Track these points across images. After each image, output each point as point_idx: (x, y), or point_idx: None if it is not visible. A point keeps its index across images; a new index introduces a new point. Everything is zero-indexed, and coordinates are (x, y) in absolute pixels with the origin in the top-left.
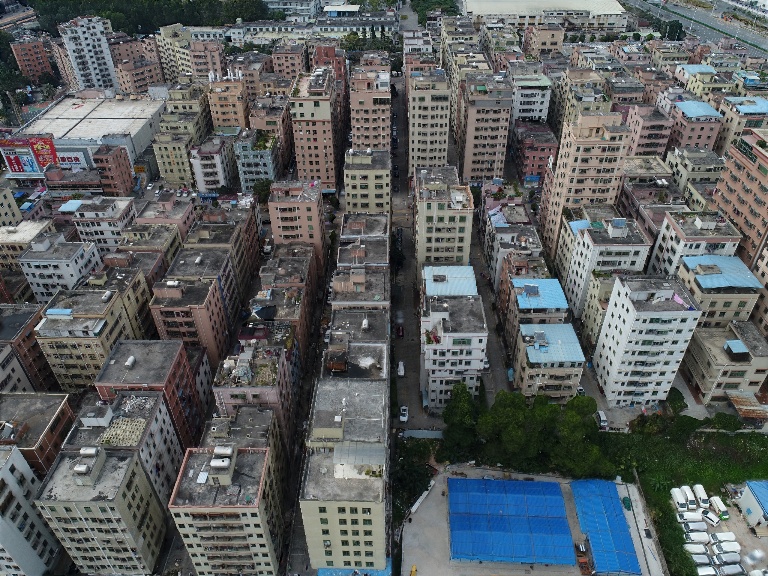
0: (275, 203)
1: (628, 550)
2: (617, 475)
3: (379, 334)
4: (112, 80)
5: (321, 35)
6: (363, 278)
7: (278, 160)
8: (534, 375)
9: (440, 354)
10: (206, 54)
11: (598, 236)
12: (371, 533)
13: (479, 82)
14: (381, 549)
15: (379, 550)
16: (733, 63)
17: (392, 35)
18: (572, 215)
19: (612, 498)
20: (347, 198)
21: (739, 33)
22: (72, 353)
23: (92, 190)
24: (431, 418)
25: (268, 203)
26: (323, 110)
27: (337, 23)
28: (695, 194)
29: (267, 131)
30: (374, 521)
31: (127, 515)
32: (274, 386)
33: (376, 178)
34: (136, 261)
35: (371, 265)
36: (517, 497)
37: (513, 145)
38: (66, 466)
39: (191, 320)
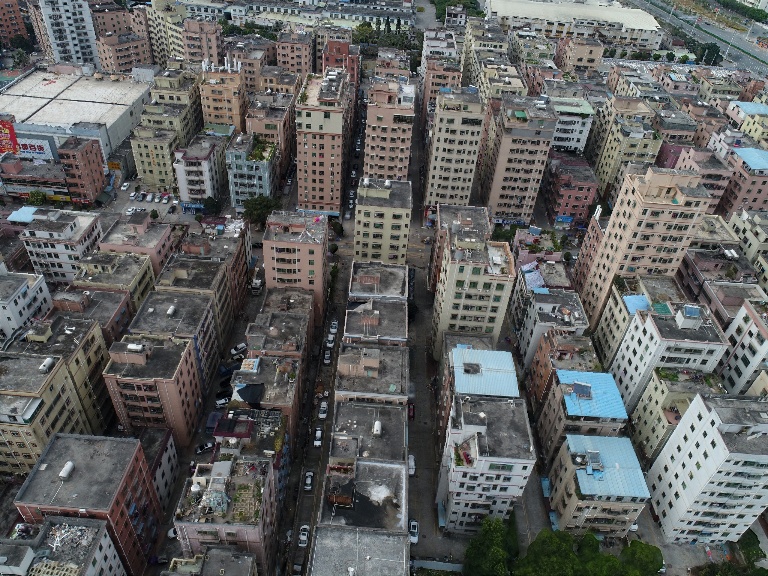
0: (271, 242)
1: None
2: None
3: (394, 443)
4: (93, 53)
5: (331, 22)
6: (377, 362)
7: (275, 171)
8: (583, 507)
9: (471, 478)
10: (201, 36)
11: (664, 325)
12: None
13: (518, 106)
14: None
15: None
16: None
17: None
18: (624, 285)
19: None
20: (357, 236)
21: None
22: None
23: (55, 188)
24: (447, 540)
25: None
26: (334, 123)
27: (349, 10)
28: None
29: (265, 135)
30: None
31: None
32: (256, 525)
33: (394, 217)
34: (93, 304)
35: (386, 339)
36: None
37: (543, 176)
38: None
39: (155, 395)
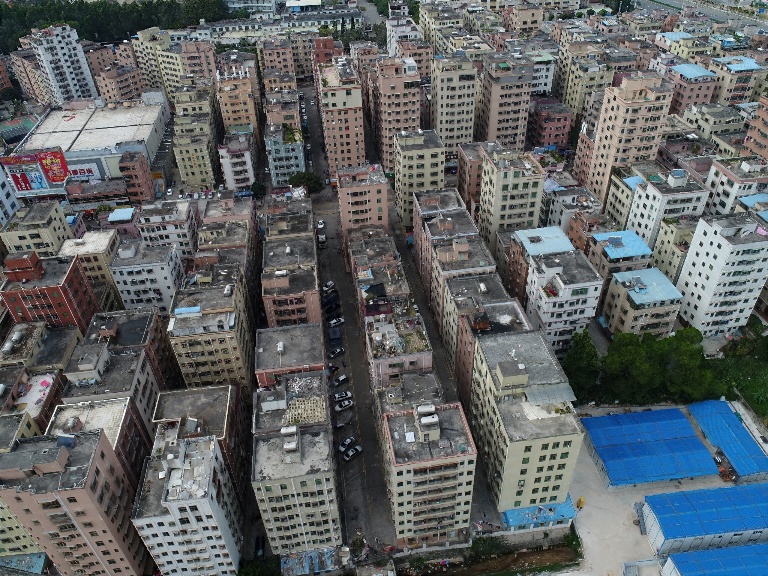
0: (347, 188)
1: (759, 454)
2: (721, 395)
3: (498, 295)
4: (90, 90)
5: (291, 30)
6: (467, 246)
7: None
8: (638, 316)
9: (559, 306)
10: (200, 55)
11: (661, 187)
12: (564, 466)
13: (500, 60)
14: (568, 481)
15: (566, 483)
16: (704, 28)
17: (361, 26)
18: (620, 173)
19: (729, 414)
20: (403, 179)
21: (678, 4)
22: (205, 350)
23: (117, 200)
24: None
25: (340, 189)
26: (355, 98)
27: (303, 18)
28: (722, 144)
29: None
30: (571, 453)
31: (334, 486)
32: (431, 351)
33: (432, 157)
34: (223, 258)
35: (463, 235)
36: (649, 425)
37: None
38: (264, 449)
39: (304, 306)
